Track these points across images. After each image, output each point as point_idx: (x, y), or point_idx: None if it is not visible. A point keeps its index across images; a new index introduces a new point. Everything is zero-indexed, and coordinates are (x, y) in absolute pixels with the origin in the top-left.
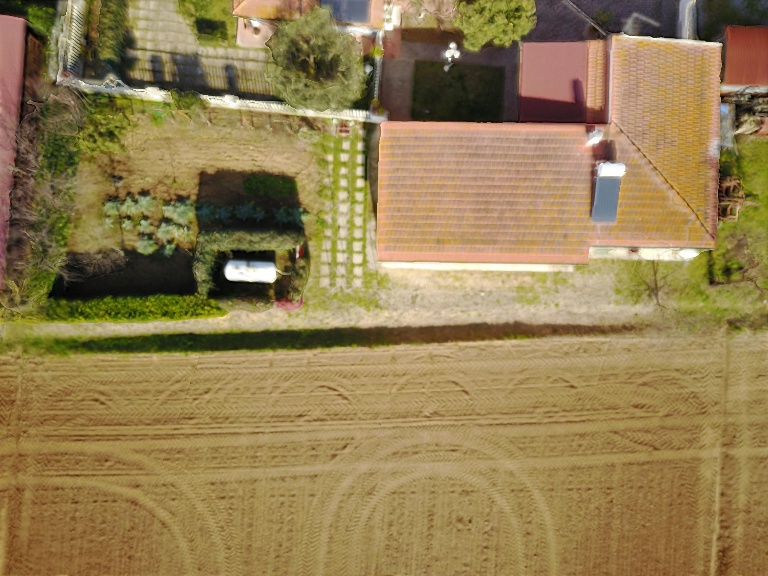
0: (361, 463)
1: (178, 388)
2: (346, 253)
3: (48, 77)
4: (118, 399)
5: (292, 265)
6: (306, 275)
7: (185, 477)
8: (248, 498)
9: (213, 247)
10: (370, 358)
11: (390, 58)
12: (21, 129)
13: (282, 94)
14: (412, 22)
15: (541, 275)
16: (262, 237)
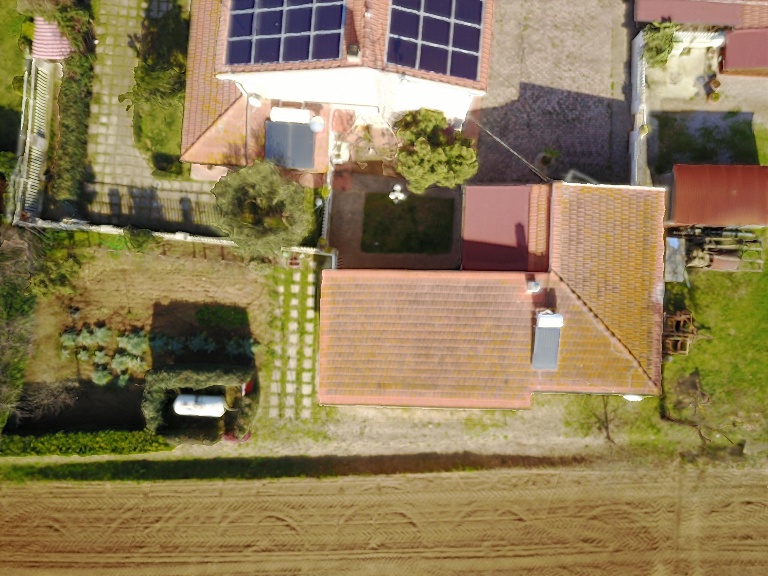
0: None
1: (130, 516)
2: (295, 384)
3: (5, 218)
4: (72, 526)
5: None
6: (253, 410)
7: None
8: None
9: (161, 385)
10: (319, 488)
11: (340, 190)
12: None
13: None
14: (362, 155)
15: None
16: (208, 376)
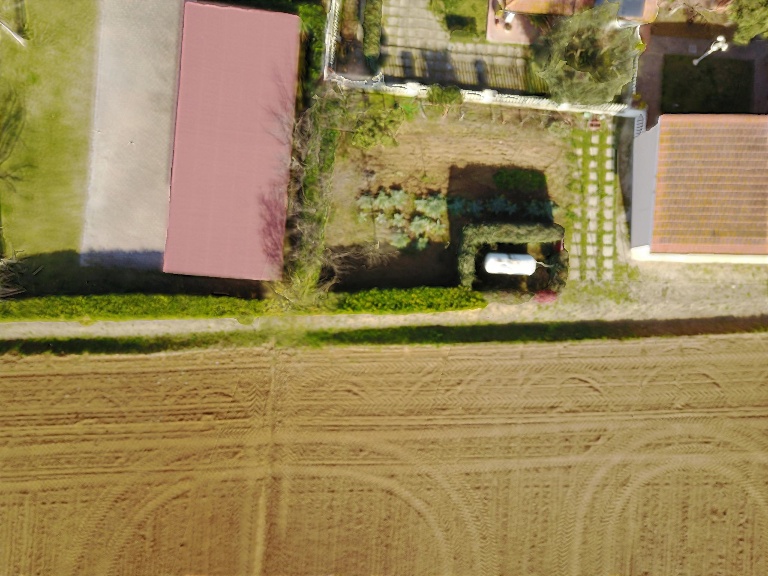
0: (614, 454)
1: (430, 379)
2: (596, 246)
3: (316, 73)
4: (370, 390)
5: (552, 257)
6: None
7: (440, 467)
8: (503, 488)
9: (480, 239)
10: (620, 350)
11: None
12: (303, 123)
13: (531, 89)
14: (661, 16)
15: None
16: (529, 229)
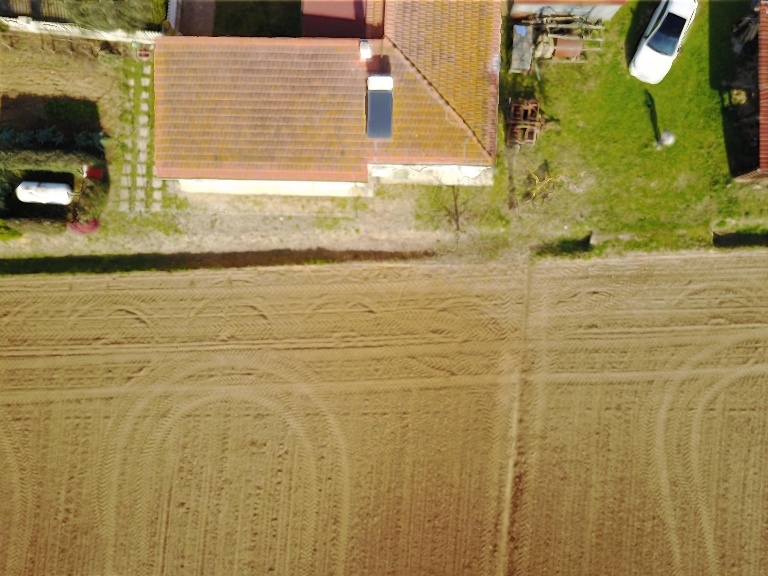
0: (157, 386)
1: None
2: (146, 177)
3: None
4: None
5: None
6: (98, 196)
7: None
8: (44, 419)
9: None
10: (169, 282)
11: None
12: None
13: None
14: None
15: (341, 200)
16: (47, 156)
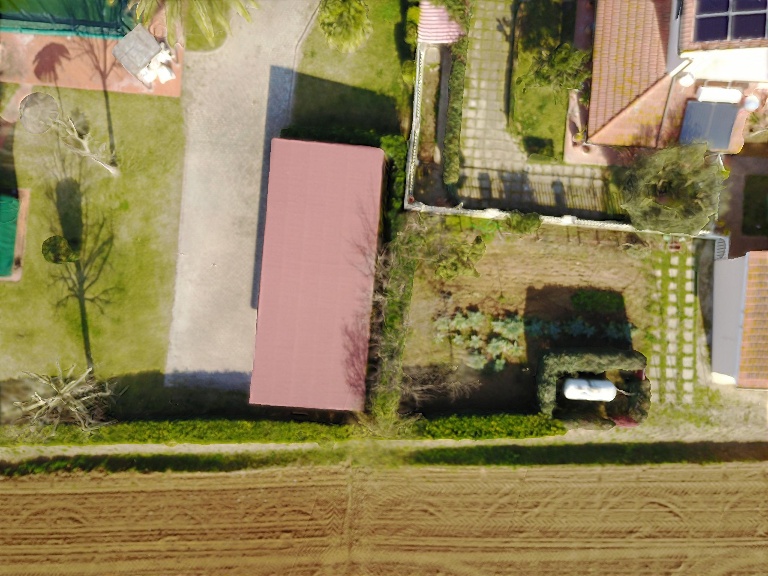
0: None
1: (507, 501)
2: (676, 369)
3: (397, 202)
4: (447, 510)
5: (633, 385)
6: None
7: None
8: None
9: (561, 369)
10: (701, 475)
11: None
12: (386, 257)
13: (609, 210)
14: None
15: None
16: (611, 360)
